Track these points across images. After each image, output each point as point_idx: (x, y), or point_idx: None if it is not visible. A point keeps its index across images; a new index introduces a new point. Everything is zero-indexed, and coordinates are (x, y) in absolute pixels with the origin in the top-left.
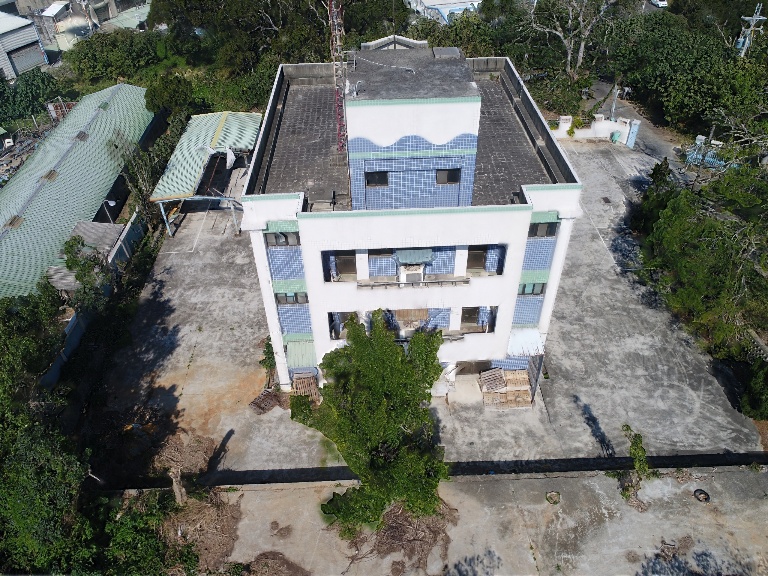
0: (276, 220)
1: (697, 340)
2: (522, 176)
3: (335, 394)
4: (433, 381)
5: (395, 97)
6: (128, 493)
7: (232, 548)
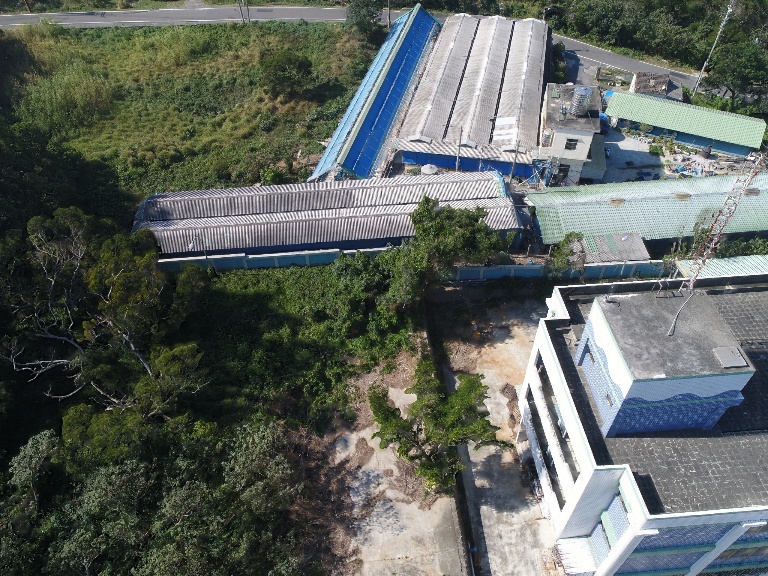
0: None
1: None
2: (685, 487)
3: (421, 374)
4: None
5: (612, 324)
6: (424, 333)
7: (396, 388)
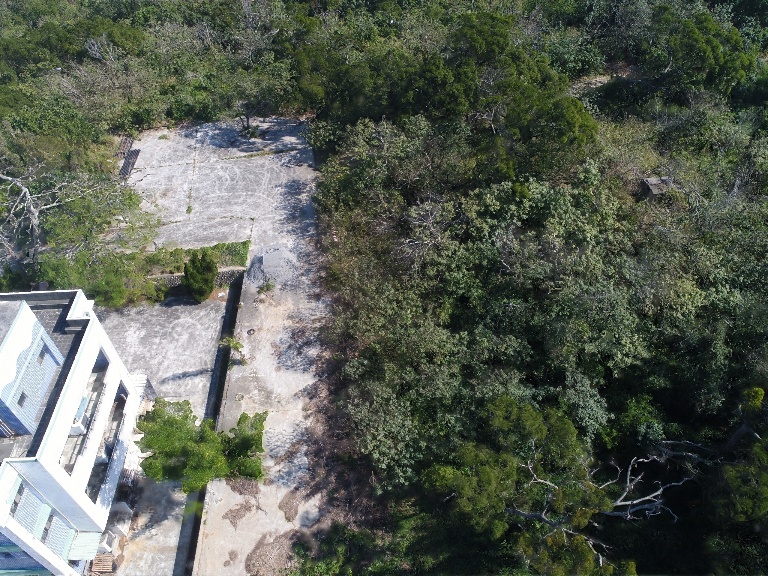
0: (8, 495)
1: (142, 305)
2: None
3: None
4: (190, 409)
5: None
6: None
7: None
